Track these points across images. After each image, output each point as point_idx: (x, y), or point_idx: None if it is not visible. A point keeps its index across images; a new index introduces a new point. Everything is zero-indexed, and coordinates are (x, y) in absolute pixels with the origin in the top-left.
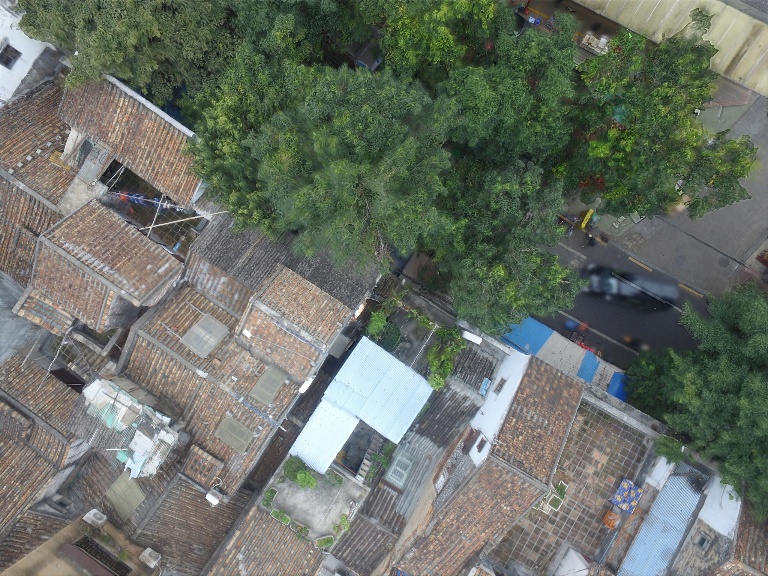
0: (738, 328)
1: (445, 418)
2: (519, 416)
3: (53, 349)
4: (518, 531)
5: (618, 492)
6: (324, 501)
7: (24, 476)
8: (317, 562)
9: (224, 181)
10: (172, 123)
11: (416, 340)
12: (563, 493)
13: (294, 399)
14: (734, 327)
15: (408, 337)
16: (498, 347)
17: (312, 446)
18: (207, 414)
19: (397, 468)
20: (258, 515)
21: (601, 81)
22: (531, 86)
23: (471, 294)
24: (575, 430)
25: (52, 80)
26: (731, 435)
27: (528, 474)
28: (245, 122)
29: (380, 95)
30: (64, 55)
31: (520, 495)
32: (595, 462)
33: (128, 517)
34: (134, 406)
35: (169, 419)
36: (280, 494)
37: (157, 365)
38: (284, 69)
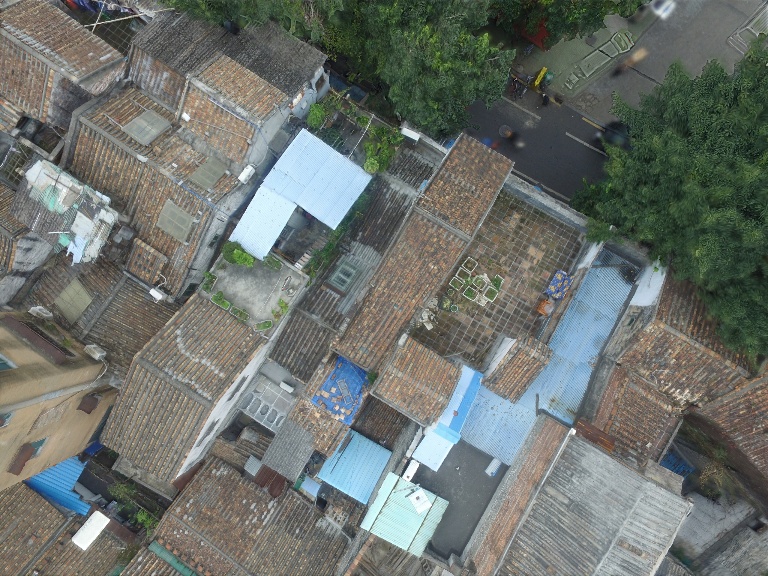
0: None
1: (386, 222)
2: (447, 181)
3: (6, 174)
4: (456, 325)
5: (552, 283)
6: (264, 289)
7: None
8: (256, 344)
9: None
10: None
11: (360, 153)
12: (498, 283)
13: (234, 188)
14: (661, 110)
15: None
16: (437, 148)
17: (251, 233)
18: (149, 205)
19: (341, 276)
20: (198, 300)
21: None
22: None
23: (402, 67)
24: (511, 227)
25: None
26: None
27: (452, 225)
28: None
29: None
30: None
31: (446, 251)
32: (531, 258)
33: (75, 320)
34: (75, 187)
35: (109, 199)
36: (221, 283)
37: (100, 157)
38: None
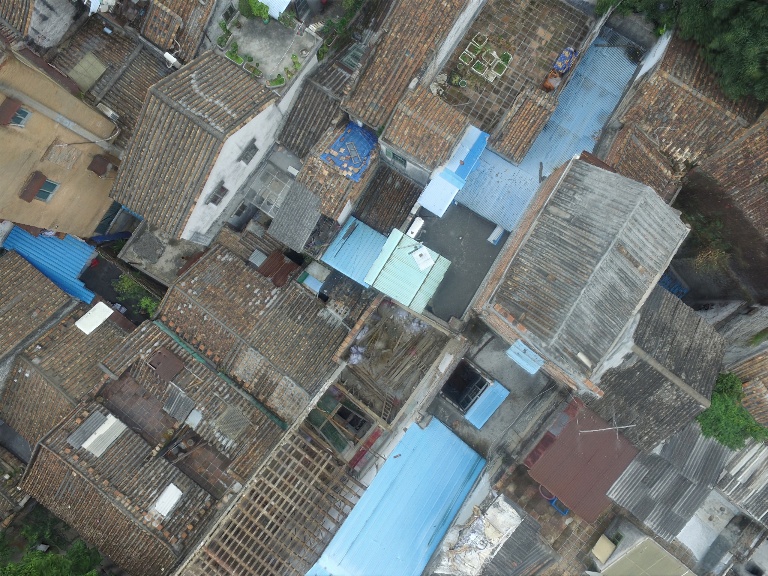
0: None
1: None
2: None
3: None
4: (463, 101)
5: (559, 59)
6: (277, 51)
7: None
8: (268, 97)
9: None
10: None
11: None
12: (507, 57)
13: None
14: None
15: None
16: None
17: None
18: None
19: (352, 61)
20: (213, 55)
21: None
22: None
23: None
24: (522, 9)
25: None
26: None
27: None
28: None
29: None
30: None
31: None
32: (539, 39)
33: (89, 88)
34: None
35: None
36: None
37: None
38: None
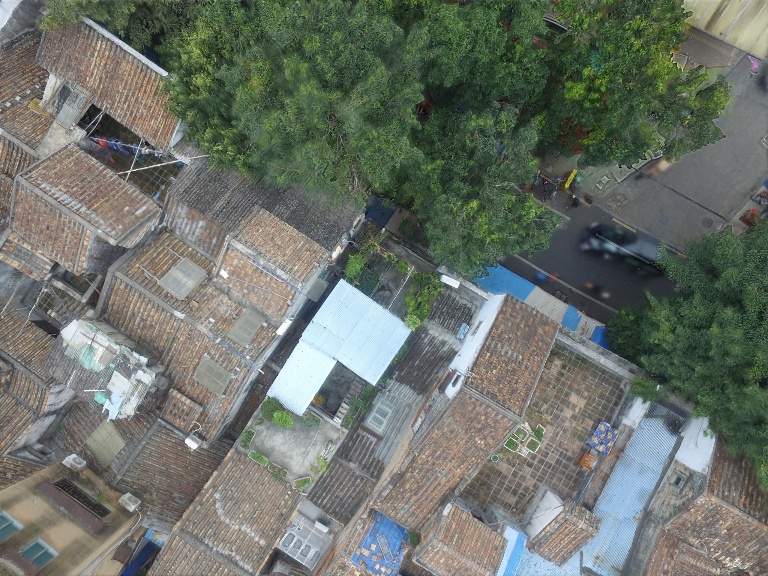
0: (712, 264)
1: (424, 364)
2: (493, 351)
3: None
4: (496, 474)
5: (595, 434)
6: (302, 443)
7: (4, 422)
8: (295, 503)
9: (199, 118)
10: (149, 65)
11: (396, 288)
12: (540, 435)
13: (272, 341)
14: (709, 267)
15: (388, 285)
16: (476, 292)
17: (290, 388)
18: (185, 357)
19: (377, 415)
20: (236, 457)
21: (574, 17)
22: (507, 27)
23: (446, 231)
24: (553, 374)
25: (33, 31)
26: (703, 367)
27: (501, 405)
28: (220, 59)
29: (351, 23)
30: (44, 6)
31: (494, 428)
32: (573, 406)
33: (108, 464)
34: (111, 346)
35: (146, 359)
36: (258, 436)
37: (135, 308)
38: (260, 9)
